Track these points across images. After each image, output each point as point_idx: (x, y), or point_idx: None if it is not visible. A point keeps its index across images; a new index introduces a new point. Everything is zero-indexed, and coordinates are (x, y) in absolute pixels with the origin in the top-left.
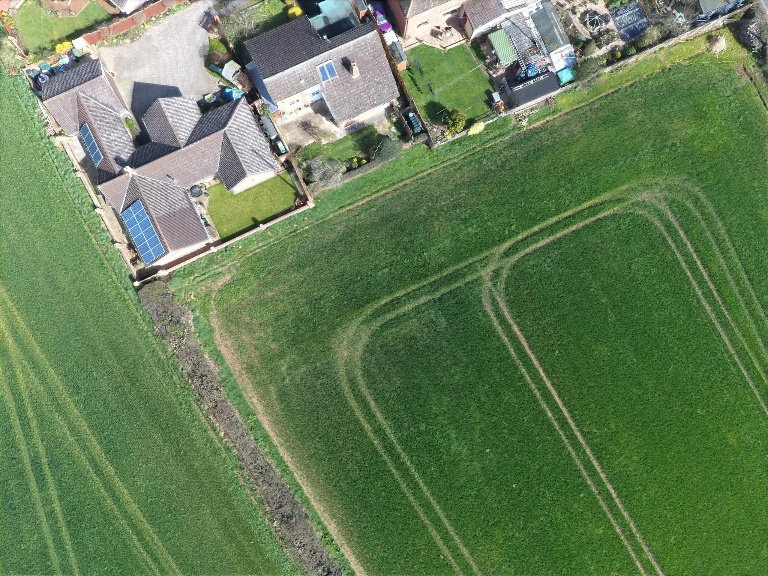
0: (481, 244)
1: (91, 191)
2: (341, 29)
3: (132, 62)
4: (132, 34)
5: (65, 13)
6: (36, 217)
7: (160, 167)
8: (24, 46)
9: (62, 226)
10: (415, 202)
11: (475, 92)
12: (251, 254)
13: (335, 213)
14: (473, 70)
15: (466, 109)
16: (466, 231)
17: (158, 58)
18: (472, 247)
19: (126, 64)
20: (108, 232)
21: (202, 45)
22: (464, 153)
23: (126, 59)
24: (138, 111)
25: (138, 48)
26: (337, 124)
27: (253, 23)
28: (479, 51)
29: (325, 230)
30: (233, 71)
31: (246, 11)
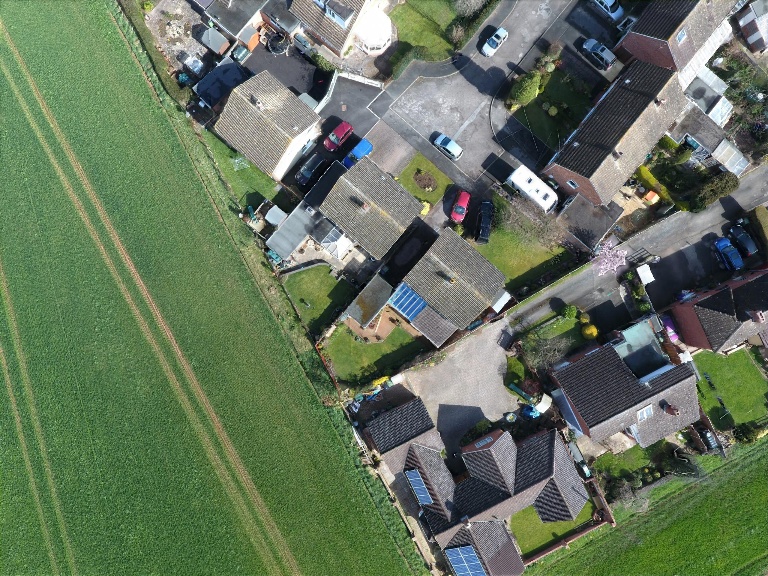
0: (763, 544)
1: (404, 516)
2: (644, 356)
3: (437, 385)
4: (436, 357)
5: (373, 339)
6: (353, 544)
7: (489, 512)
8: (336, 374)
9: (377, 552)
10: (701, 506)
11: (755, 395)
12: (550, 567)
13: (626, 521)
14: (753, 373)
15: (747, 412)
16: (749, 532)
17: (460, 379)
18: (755, 548)
19: (431, 387)
20: (422, 557)
21: (500, 363)
22: (745, 454)
23: (431, 382)
24: (443, 433)
25: (442, 371)
26: (630, 437)
27: (557, 349)
28: (758, 354)
29: (618, 538)
30: (548, 407)
31: (541, 328)
